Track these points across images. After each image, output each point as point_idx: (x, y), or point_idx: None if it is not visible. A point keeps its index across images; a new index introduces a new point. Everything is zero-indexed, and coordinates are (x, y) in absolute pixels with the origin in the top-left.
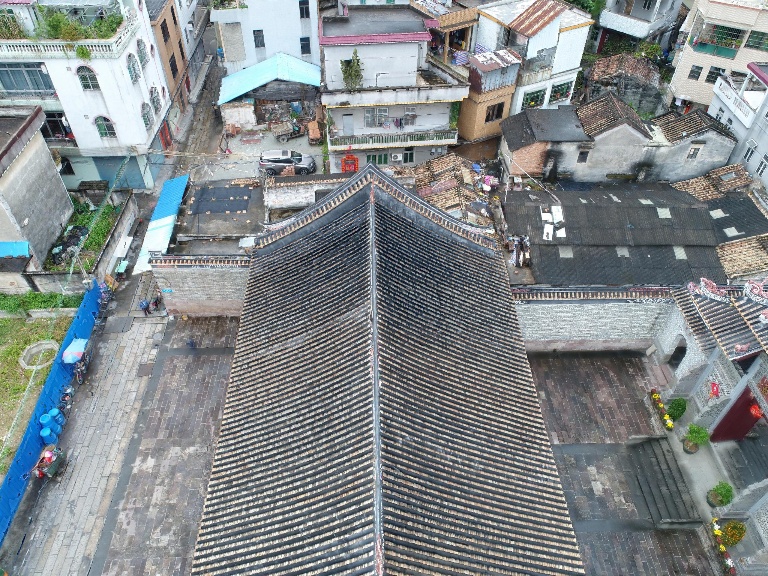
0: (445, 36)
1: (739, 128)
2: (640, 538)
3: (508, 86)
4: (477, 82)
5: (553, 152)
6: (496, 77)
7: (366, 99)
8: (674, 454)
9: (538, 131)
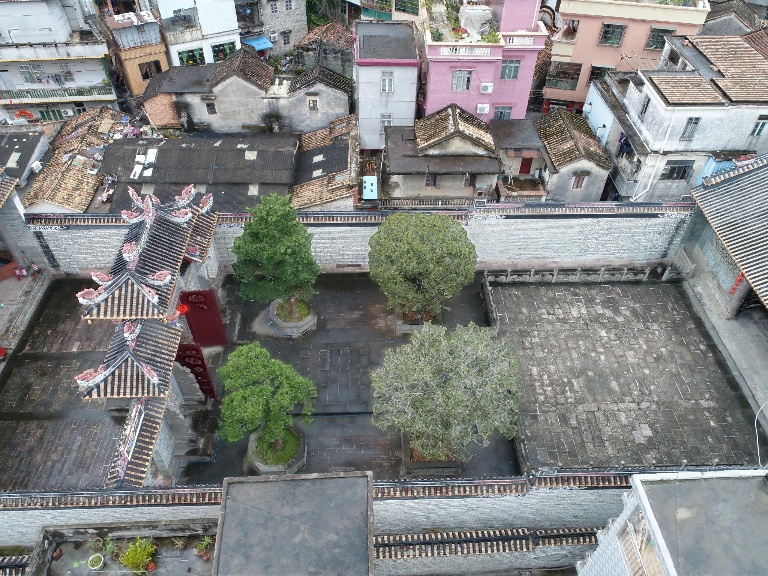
0: None
1: None
2: (92, 424)
3: (154, 44)
4: (114, 39)
5: (181, 104)
6: (133, 35)
7: (6, 55)
8: None
9: (166, 84)
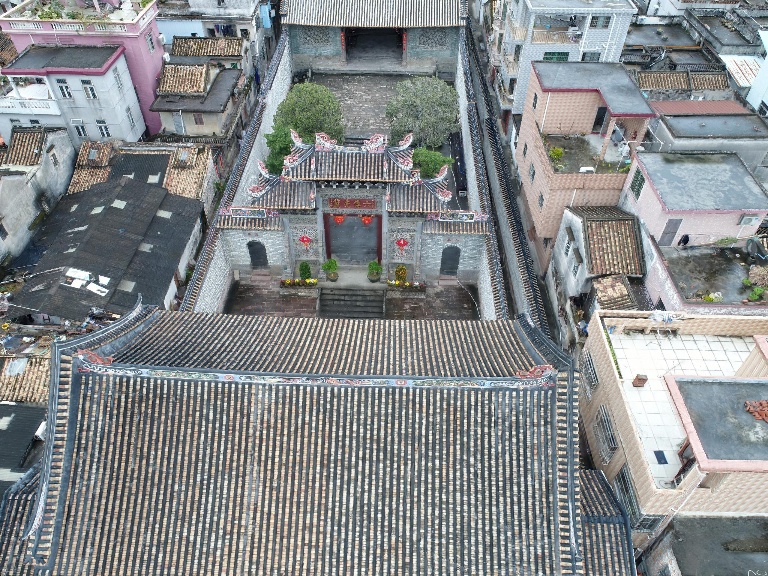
0: None
1: (51, 120)
2: None
3: None
4: None
5: None
6: None
7: None
8: (335, 288)
9: None
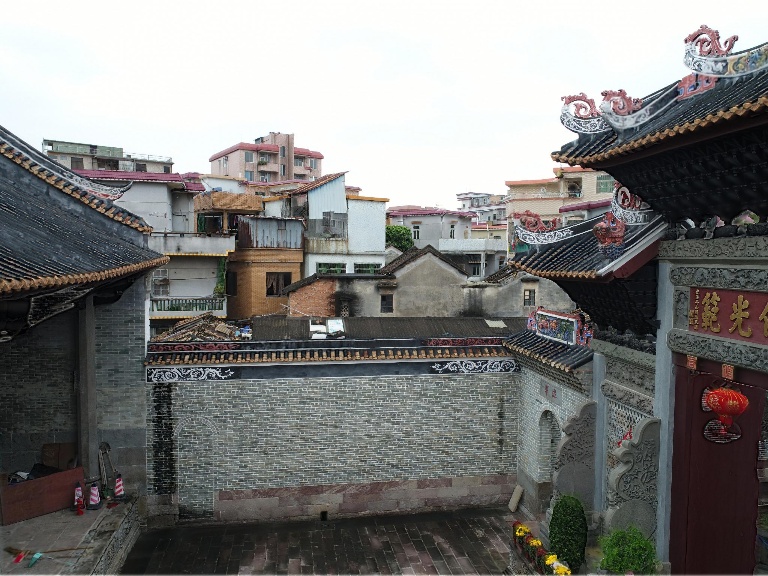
0: (222, 219)
1: None
2: None
3: (291, 250)
4: (246, 234)
5: (344, 296)
6: (271, 232)
7: None
8: None
9: None
